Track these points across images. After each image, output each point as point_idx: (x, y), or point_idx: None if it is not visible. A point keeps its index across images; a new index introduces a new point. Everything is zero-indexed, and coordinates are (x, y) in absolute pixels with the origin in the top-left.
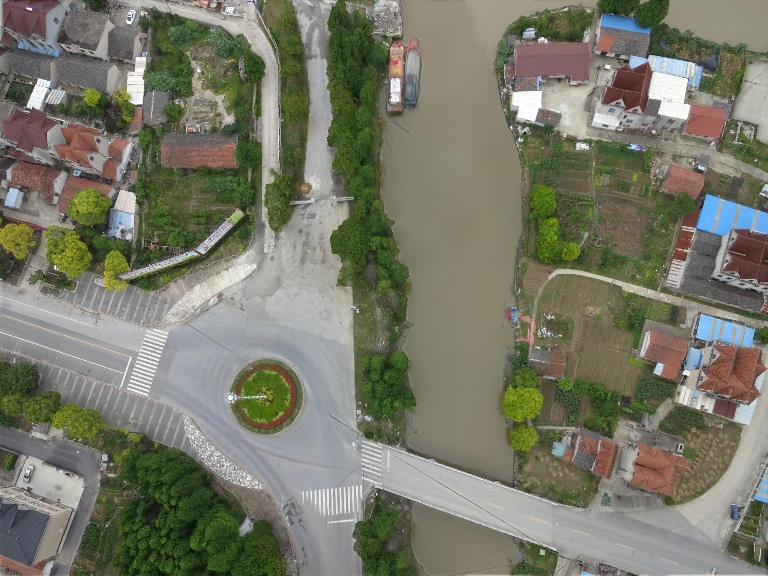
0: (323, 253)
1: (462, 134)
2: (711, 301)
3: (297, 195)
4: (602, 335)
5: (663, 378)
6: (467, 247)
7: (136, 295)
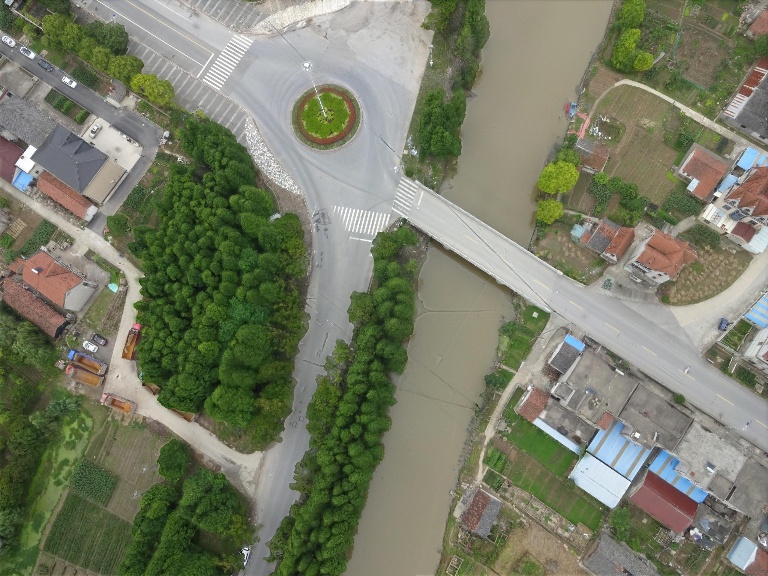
0: (414, 7)
1: None
2: (761, 142)
3: None
4: (649, 146)
5: (694, 197)
6: (545, 50)
7: (233, 2)
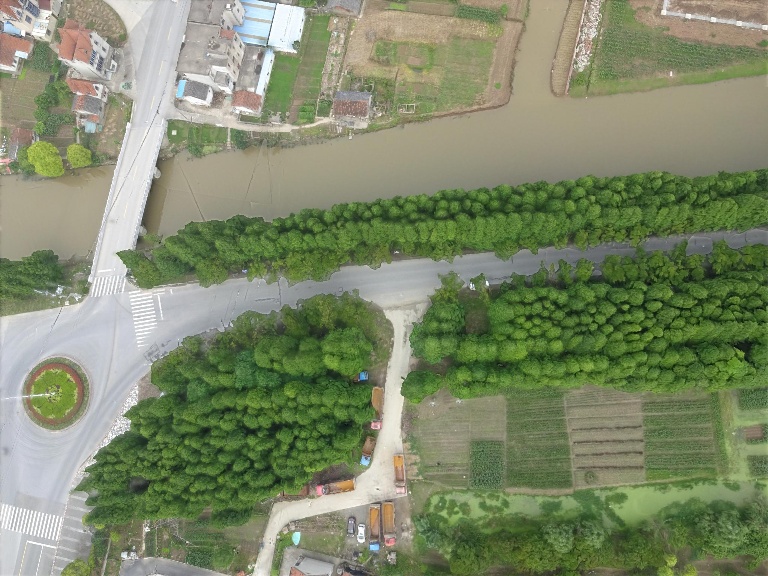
0: None
1: None
2: None
3: None
4: (2, 103)
5: (33, 52)
6: None
7: None
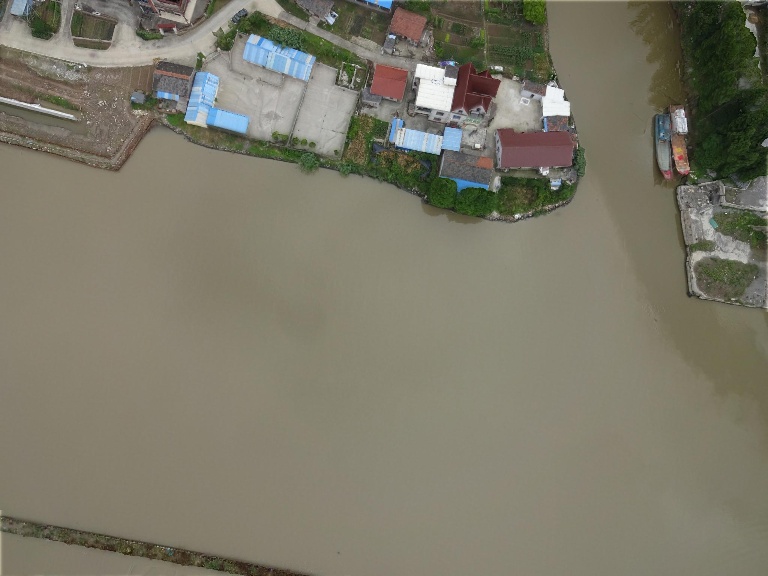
0: None
1: (599, 103)
2: None
3: (760, 12)
4: None
5: None
6: None
7: None
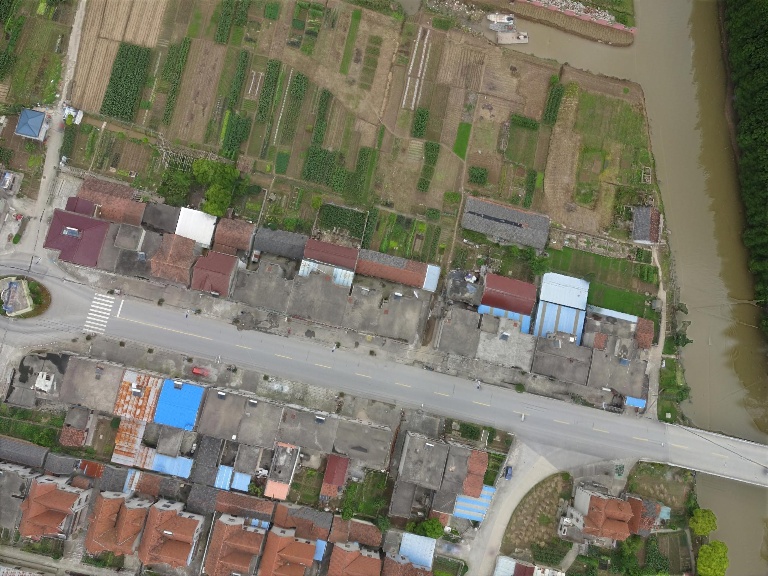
0: None
1: None
2: None
3: None
4: None
5: None
6: None
7: None
